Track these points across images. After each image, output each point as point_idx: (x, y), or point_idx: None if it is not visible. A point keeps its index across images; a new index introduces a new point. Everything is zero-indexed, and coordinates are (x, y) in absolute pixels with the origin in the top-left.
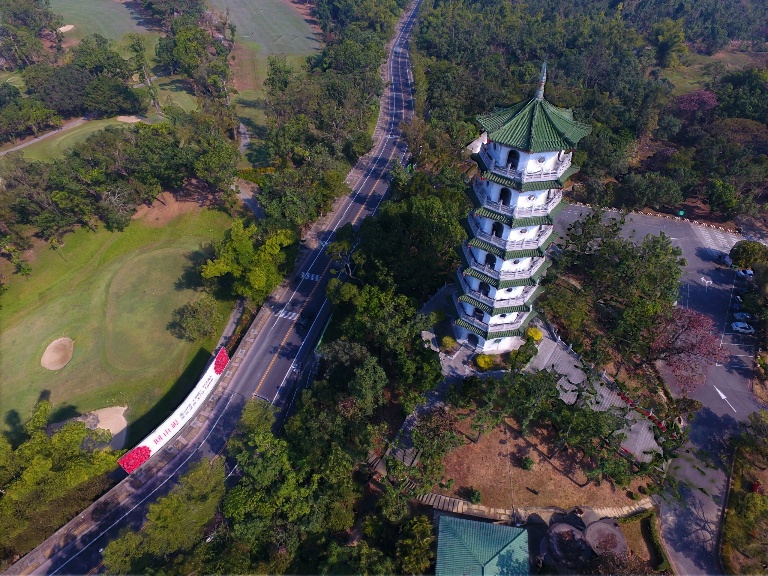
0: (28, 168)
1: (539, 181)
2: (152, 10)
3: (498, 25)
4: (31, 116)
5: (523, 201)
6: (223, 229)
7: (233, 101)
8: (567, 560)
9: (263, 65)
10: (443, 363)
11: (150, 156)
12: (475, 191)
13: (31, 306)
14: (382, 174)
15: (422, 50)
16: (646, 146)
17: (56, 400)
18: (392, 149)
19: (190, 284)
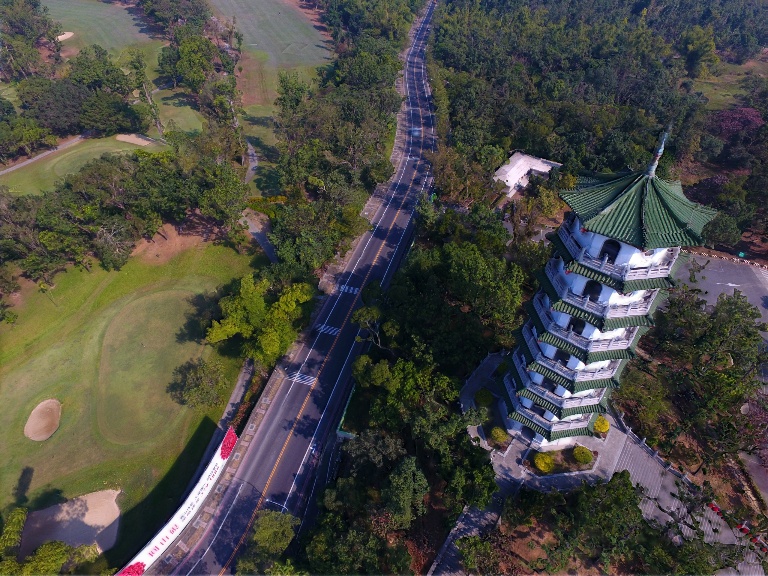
0: (15, 202)
1: (644, 278)
2: (155, 17)
3: (519, 34)
4: (24, 136)
5: (617, 297)
6: (230, 268)
7: (240, 117)
8: None
9: (271, 76)
10: (493, 462)
11: (149, 190)
12: (548, 276)
13: (16, 360)
14: (403, 203)
15: (438, 60)
16: (685, 168)
17: (39, 481)
18: (412, 173)
19: (193, 335)
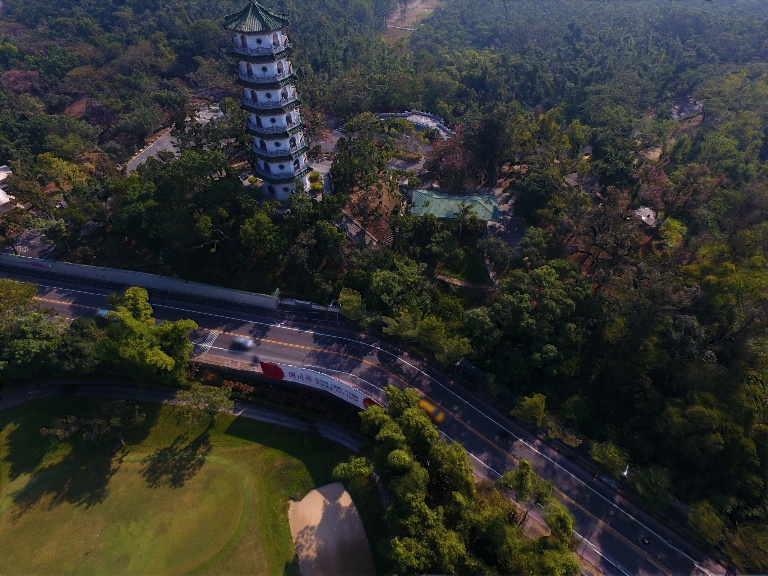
0: None
1: None
2: None
3: None
4: None
5: (286, 64)
6: None
7: None
8: (424, 182)
9: None
10: None
11: None
12: (261, 82)
13: None
14: None
15: None
16: None
17: None
18: None
19: (98, 483)
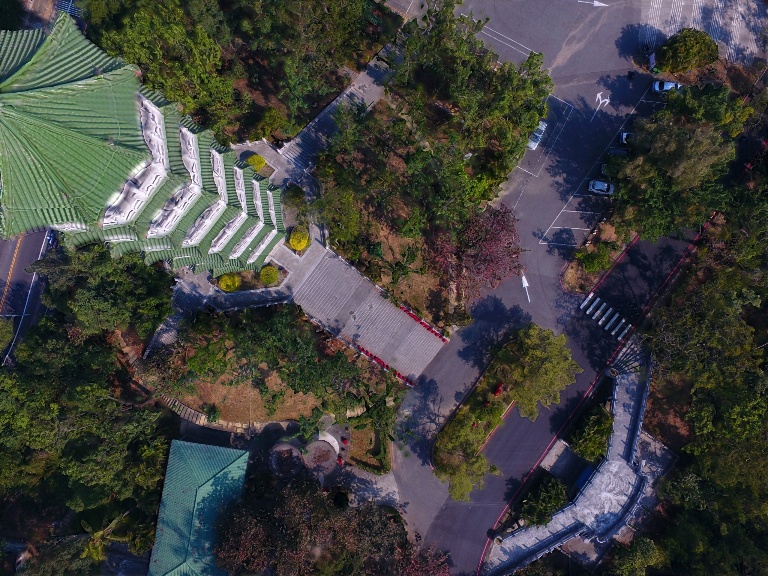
0: None
1: None
2: None
3: None
4: None
5: None
6: None
7: None
8: (280, 473)
9: None
10: (185, 279)
11: None
12: None
13: None
14: None
15: None
16: None
17: None
18: None
19: None
